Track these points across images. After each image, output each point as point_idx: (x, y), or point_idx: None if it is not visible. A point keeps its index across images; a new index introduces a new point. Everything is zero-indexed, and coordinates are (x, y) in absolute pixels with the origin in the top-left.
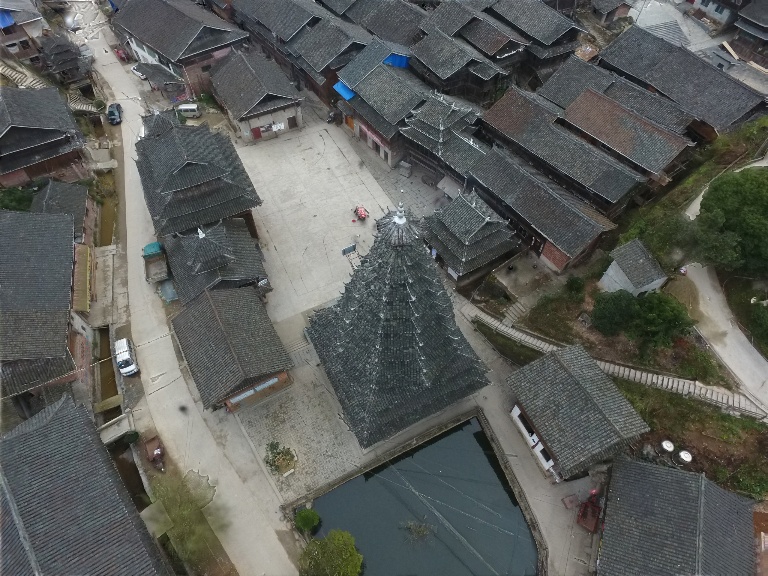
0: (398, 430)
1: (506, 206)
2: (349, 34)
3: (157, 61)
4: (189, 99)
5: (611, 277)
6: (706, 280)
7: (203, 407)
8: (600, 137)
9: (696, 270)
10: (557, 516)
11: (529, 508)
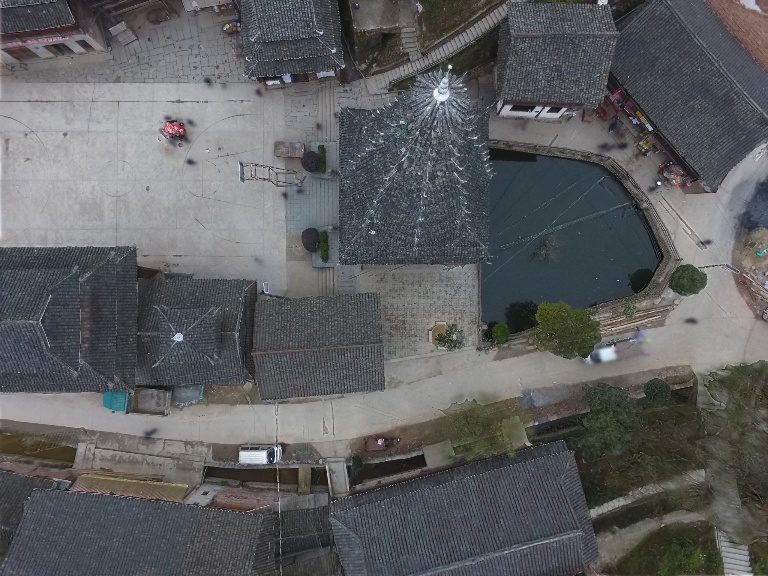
0: None
1: None
2: None
3: None
4: None
5: None
6: None
7: (381, 391)
8: None
9: None
10: (591, 134)
11: (577, 152)
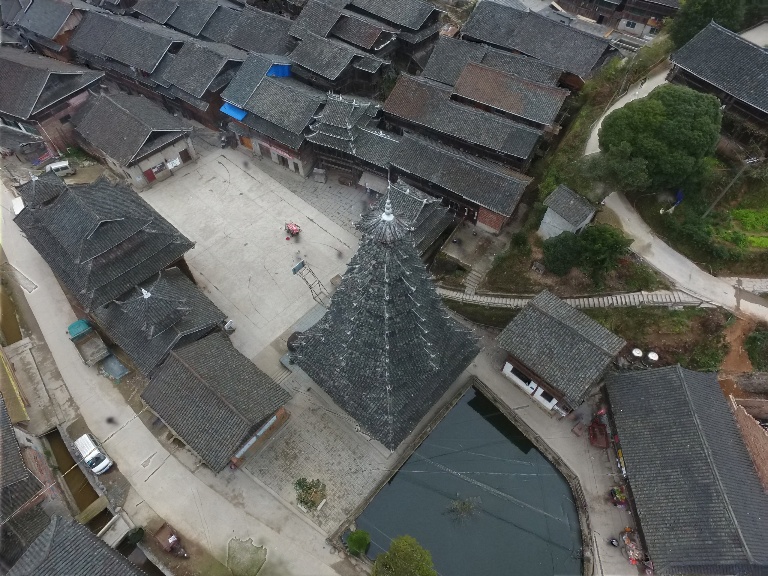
0: (417, 422)
1: (433, 186)
2: (220, 53)
3: (0, 123)
4: (54, 157)
5: (549, 224)
6: (620, 205)
7: (214, 472)
8: (493, 104)
9: (610, 199)
10: (573, 446)
11: (549, 448)
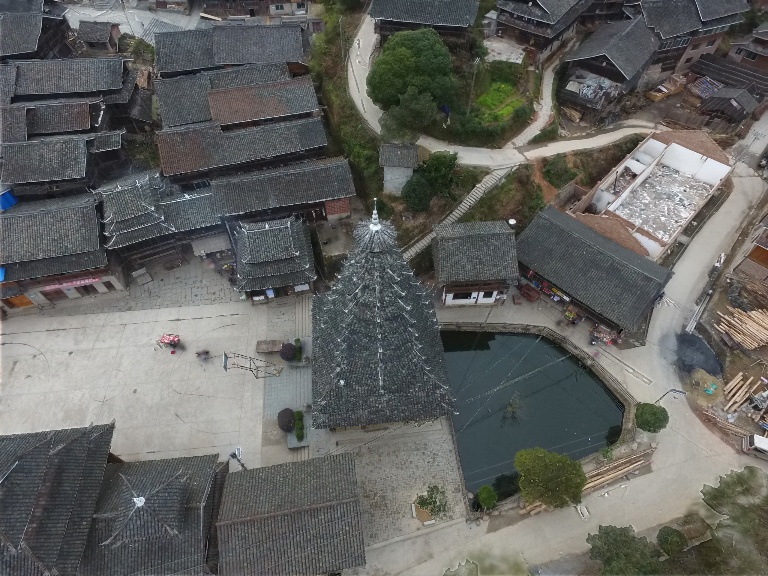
0: None
1: (273, 211)
2: None
3: None
4: None
5: (391, 179)
6: None
7: (362, 567)
8: (260, 116)
9: None
10: (524, 312)
11: (517, 325)
